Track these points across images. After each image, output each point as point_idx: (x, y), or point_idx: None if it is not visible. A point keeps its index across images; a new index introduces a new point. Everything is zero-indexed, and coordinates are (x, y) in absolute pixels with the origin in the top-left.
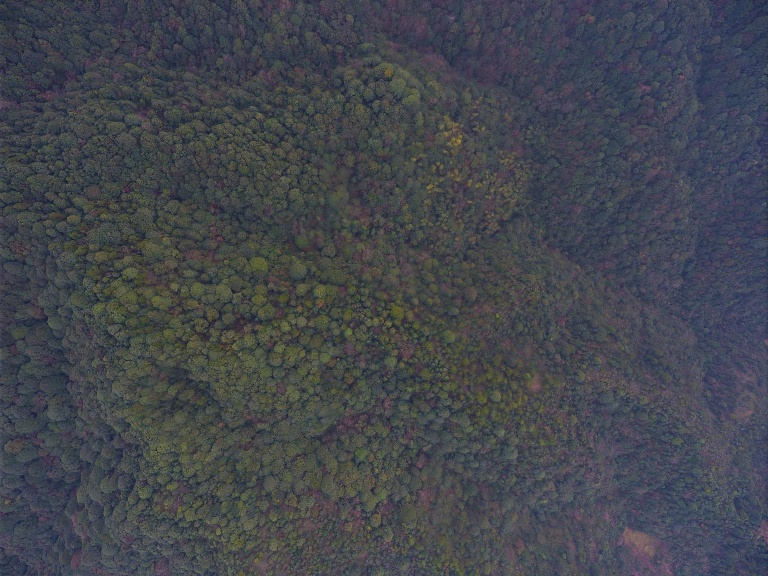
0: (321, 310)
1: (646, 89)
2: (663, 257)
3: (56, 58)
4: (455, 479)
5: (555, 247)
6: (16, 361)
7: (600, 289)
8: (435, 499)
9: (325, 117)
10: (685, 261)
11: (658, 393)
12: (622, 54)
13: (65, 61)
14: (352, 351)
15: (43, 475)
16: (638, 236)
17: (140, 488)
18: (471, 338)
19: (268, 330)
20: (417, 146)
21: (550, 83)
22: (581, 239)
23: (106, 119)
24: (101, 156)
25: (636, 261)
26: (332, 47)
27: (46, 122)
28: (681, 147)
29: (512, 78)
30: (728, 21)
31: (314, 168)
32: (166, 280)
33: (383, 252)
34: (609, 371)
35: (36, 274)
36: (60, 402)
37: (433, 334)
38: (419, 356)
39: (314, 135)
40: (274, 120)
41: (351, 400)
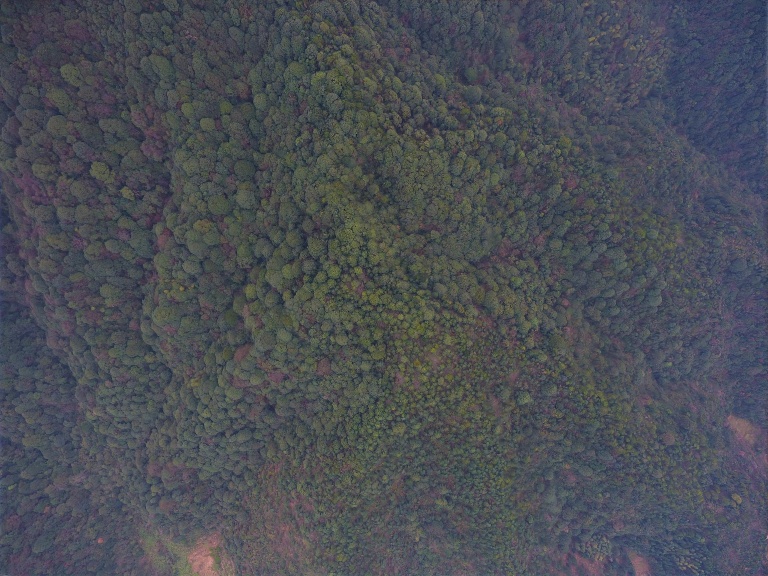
0: (499, 128)
1: None
2: None
3: None
4: (590, 329)
5: (683, 133)
6: (219, 136)
7: (724, 177)
8: (578, 338)
9: None
10: None
11: None
12: None
13: None
14: (518, 178)
15: (220, 264)
16: None
17: (332, 265)
18: (627, 182)
19: (456, 134)
20: None
21: None
22: (710, 127)
23: None
24: None
25: (762, 152)
26: None
27: None
28: None
29: None
30: None
31: None
32: (373, 67)
33: (543, 97)
34: (744, 239)
35: (258, 42)
36: (248, 188)
37: (596, 170)
38: (585, 186)
39: None
40: None
41: (511, 228)
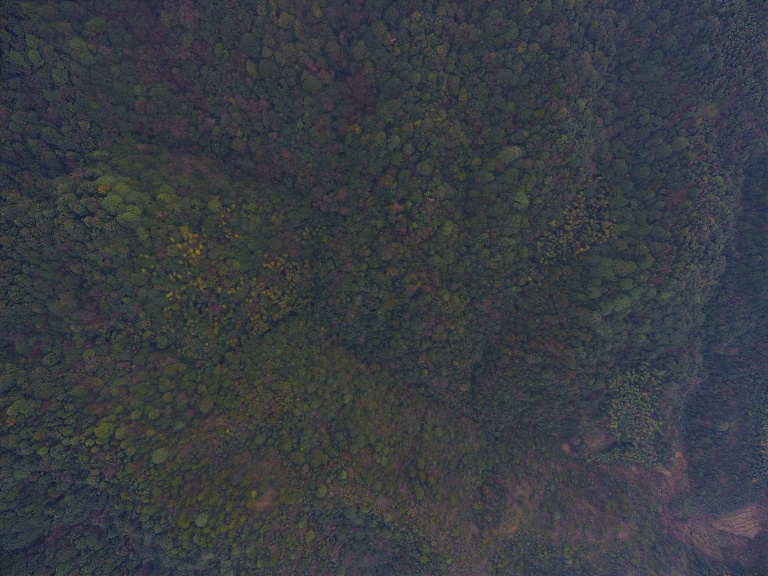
0: (12, 428)
1: (398, 208)
2: (444, 363)
3: None
4: None
5: (339, 345)
6: None
7: (381, 390)
8: None
9: (32, 231)
10: (475, 365)
11: (403, 512)
12: (382, 169)
13: None
14: None
15: None
16: (414, 343)
17: None
18: (190, 455)
19: None
20: (146, 258)
21: (329, 185)
22: (365, 339)
23: None
24: None
25: (418, 365)
26: (63, 153)
27: None
28: (445, 263)
29: (292, 177)
30: (488, 144)
31: (27, 278)
32: None
33: (115, 359)
34: (353, 487)
35: None
36: None
37: (142, 453)
38: (119, 477)
39: (23, 247)
40: None
41: (56, 514)
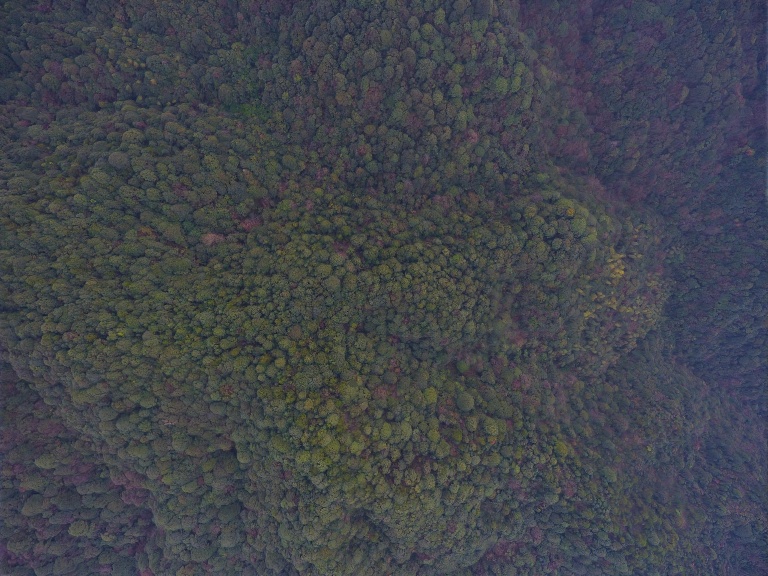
0: (493, 447)
1: None
2: None
3: (256, 187)
4: None
5: (683, 362)
6: (202, 492)
7: (726, 408)
8: None
9: (507, 253)
10: None
11: None
12: None
13: (262, 188)
14: (513, 484)
15: None
16: None
17: None
18: (626, 474)
19: (447, 471)
20: (584, 278)
21: (696, 205)
22: (710, 356)
23: (314, 261)
24: (308, 298)
25: (764, 382)
26: (508, 176)
27: (254, 259)
28: None
29: (658, 197)
30: None
31: (487, 299)
32: (360, 423)
33: (538, 378)
34: (749, 505)
35: (240, 416)
36: (233, 529)
37: (594, 471)
38: (583, 496)
39: (493, 269)
40: (460, 256)
41: (507, 532)
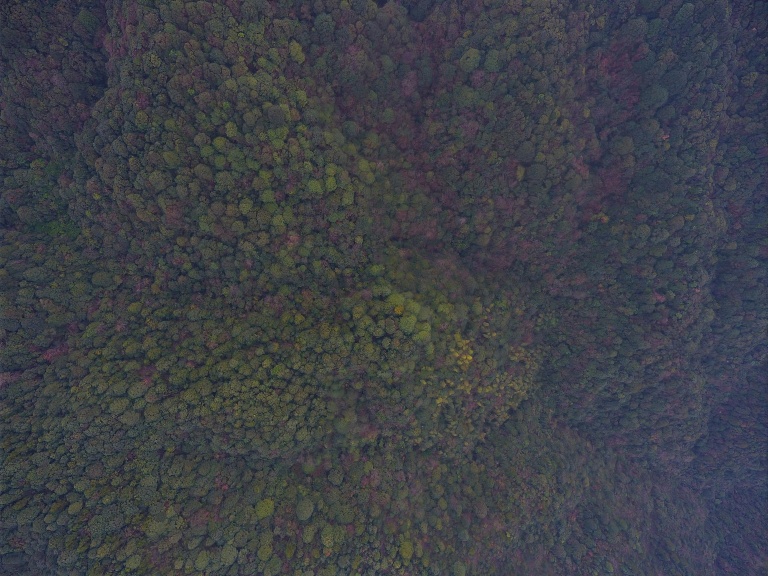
0: (329, 558)
1: (661, 299)
2: (675, 438)
3: (57, 315)
4: None
5: (565, 425)
6: None
7: (611, 468)
8: None
9: (334, 357)
10: None
11: None
12: (636, 259)
13: (67, 314)
14: None
15: None
16: (650, 422)
17: None
18: (481, 565)
19: None
20: (427, 370)
21: (561, 270)
22: (591, 418)
23: (109, 396)
24: (104, 436)
25: (647, 441)
26: (341, 270)
27: (47, 399)
28: None
29: (523, 264)
30: (745, 228)
31: (322, 402)
32: (170, 558)
33: (391, 470)
34: None
35: (36, 565)
36: None
37: (443, 569)
38: None
39: (322, 373)
40: (281, 367)
41: None
